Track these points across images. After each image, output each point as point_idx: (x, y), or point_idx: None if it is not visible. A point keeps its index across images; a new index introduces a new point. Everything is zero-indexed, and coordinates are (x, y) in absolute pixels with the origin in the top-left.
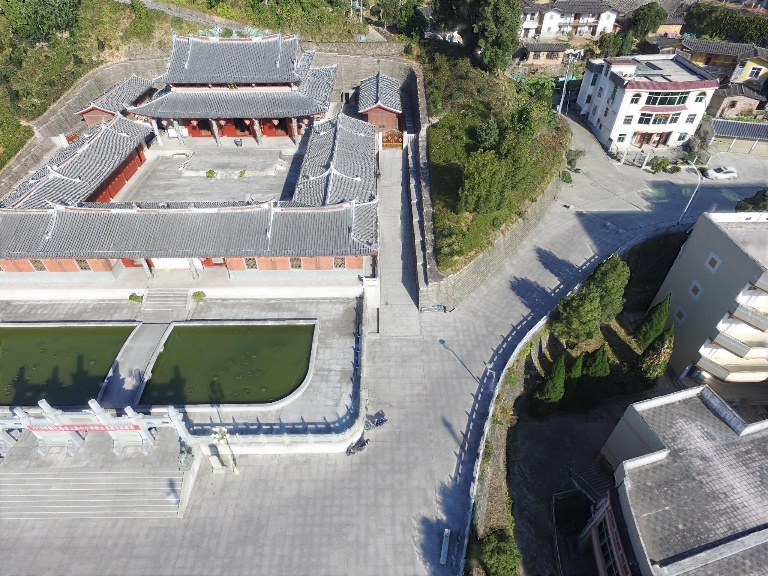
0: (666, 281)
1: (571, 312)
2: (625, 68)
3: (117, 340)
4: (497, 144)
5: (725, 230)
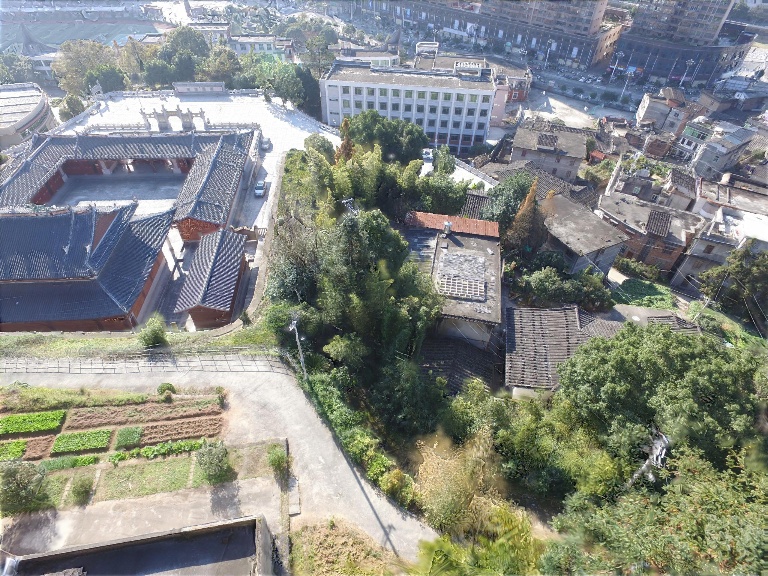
0: None
1: None
2: None
3: None
4: None
5: None
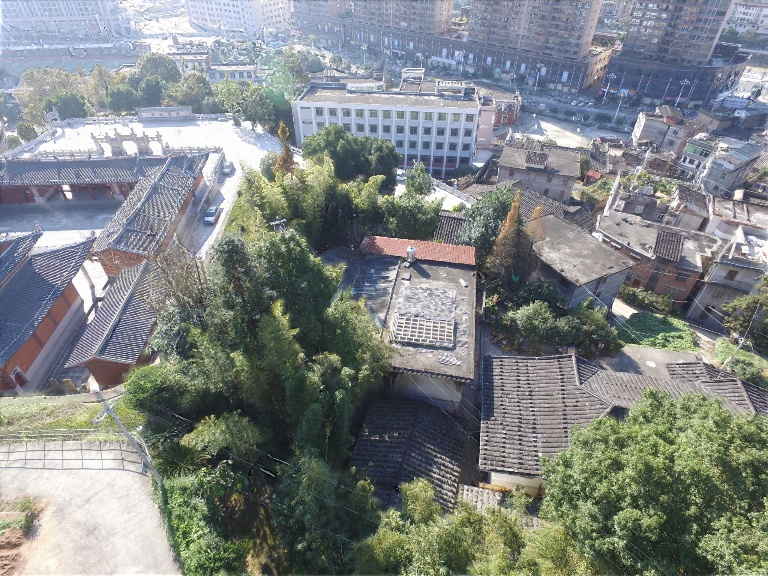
0: None
1: None
2: None
3: None
4: None
5: None
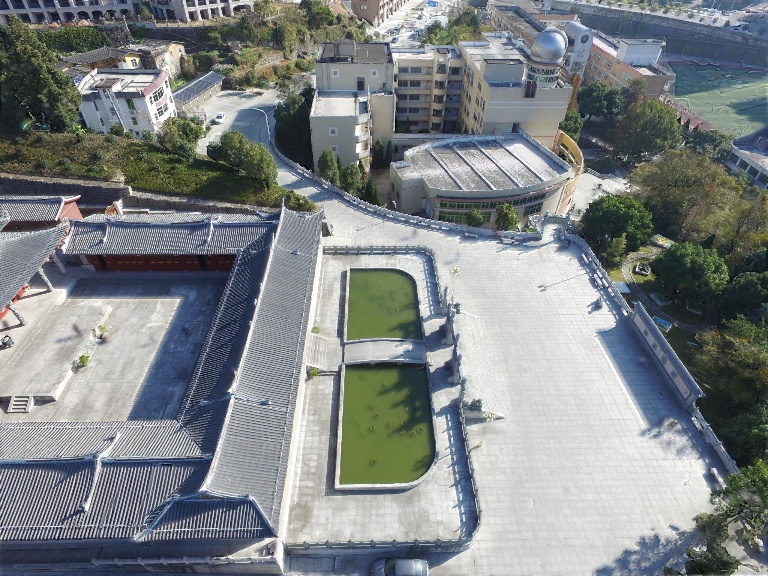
0: (315, 160)
1: (355, 177)
2: (117, 86)
3: (360, 376)
4: (225, 145)
5: (327, 115)
